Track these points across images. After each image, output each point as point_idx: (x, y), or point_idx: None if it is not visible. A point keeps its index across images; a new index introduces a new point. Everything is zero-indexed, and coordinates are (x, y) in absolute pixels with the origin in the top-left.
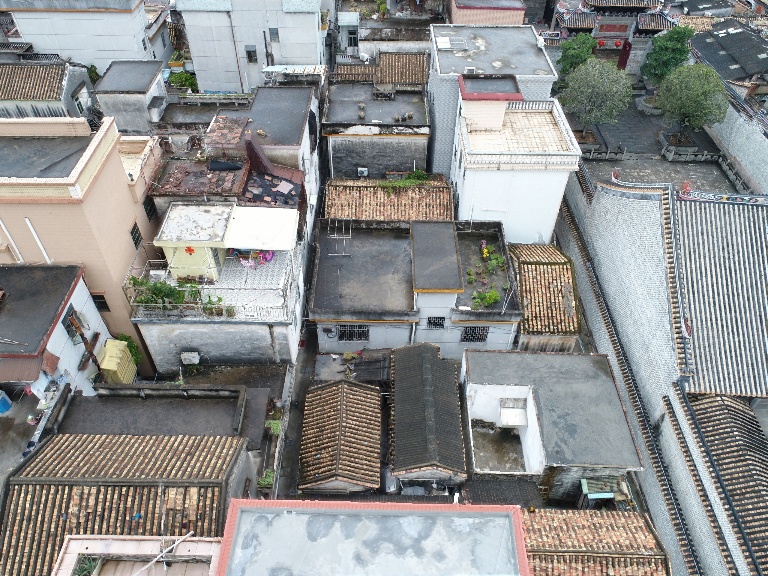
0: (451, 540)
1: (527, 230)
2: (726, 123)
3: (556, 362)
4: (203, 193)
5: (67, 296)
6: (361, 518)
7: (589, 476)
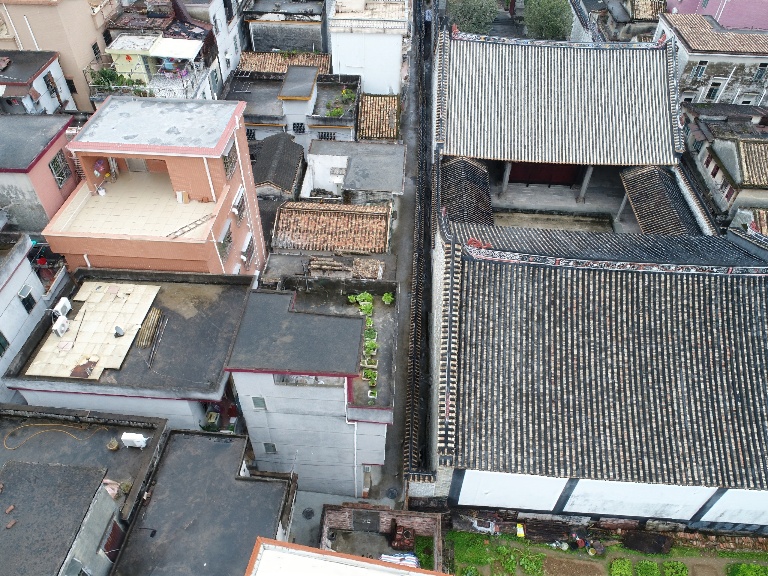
0: (208, 109)
1: (382, 84)
2: (578, 38)
3: (370, 147)
4: (141, 27)
5: (47, 63)
6: (168, 103)
7: (372, 201)
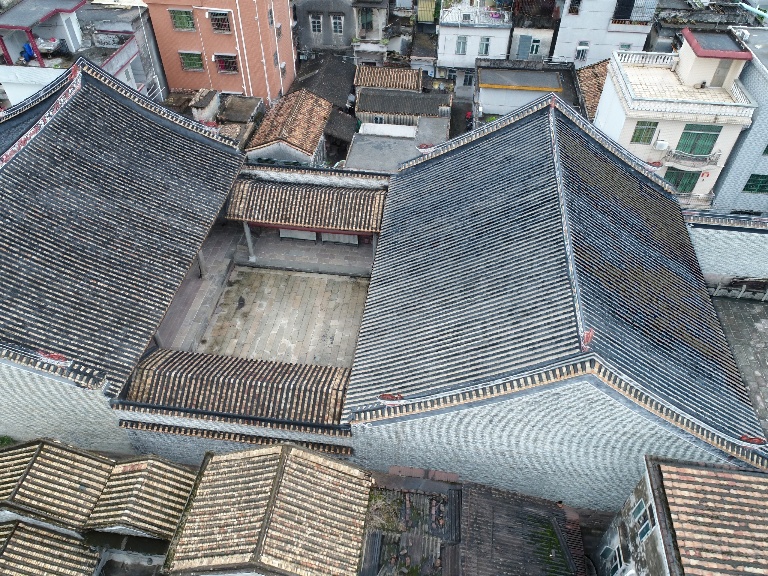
0: None
1: None
2: None
3: None
4: None
5: None
6: None
7: None
